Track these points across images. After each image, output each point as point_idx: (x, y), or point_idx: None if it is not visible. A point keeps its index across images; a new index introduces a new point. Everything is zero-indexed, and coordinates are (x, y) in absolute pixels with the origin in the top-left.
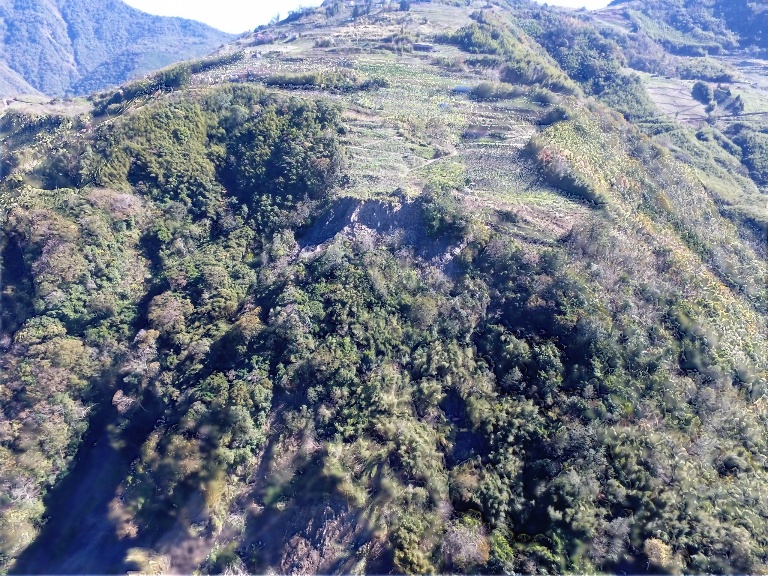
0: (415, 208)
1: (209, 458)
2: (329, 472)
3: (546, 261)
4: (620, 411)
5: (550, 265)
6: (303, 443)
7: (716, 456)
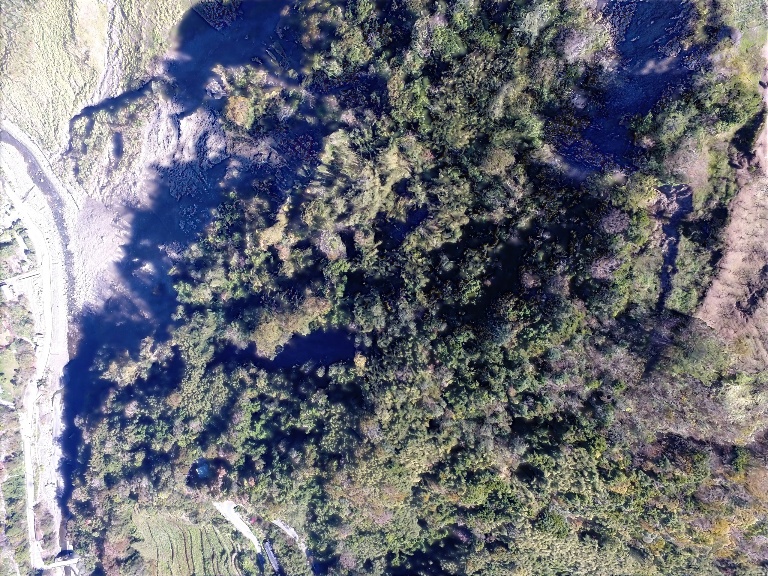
0: (679, 78)
1: (313, 52)
2: (323, 142)
3: (587, 281)
4: (425, 345)
5: (585, 286)
6: (347, 111)
7: (432, 414)
